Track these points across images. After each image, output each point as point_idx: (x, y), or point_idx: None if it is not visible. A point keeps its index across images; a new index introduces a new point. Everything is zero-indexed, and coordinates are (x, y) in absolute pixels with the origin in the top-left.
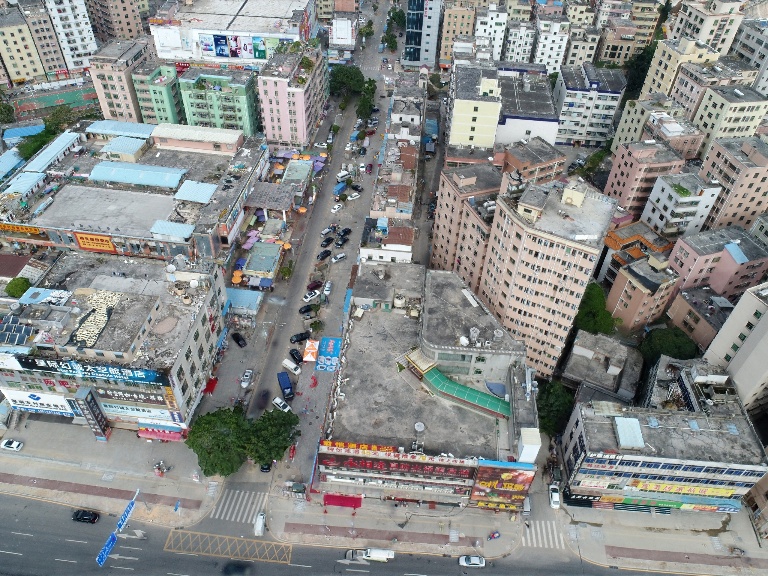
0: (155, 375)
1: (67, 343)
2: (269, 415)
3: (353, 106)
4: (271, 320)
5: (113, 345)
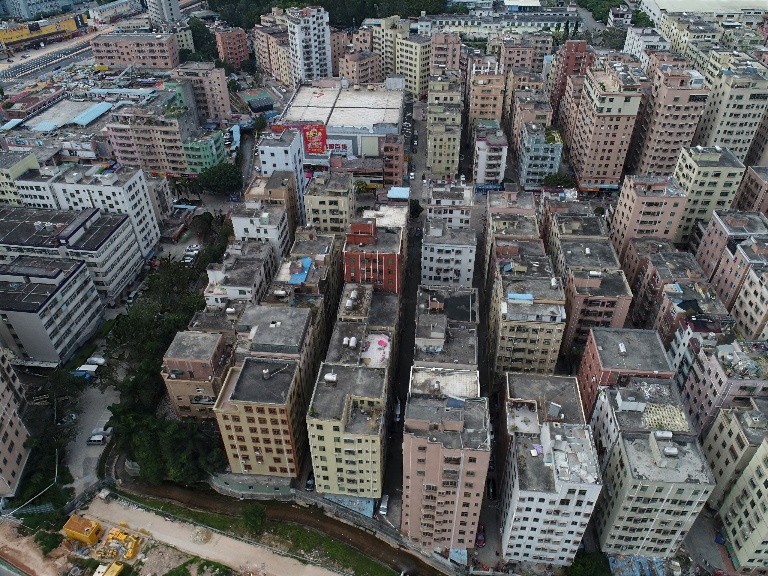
0: None
1: None
2: None
3: (208, 198)
4: None
5: None
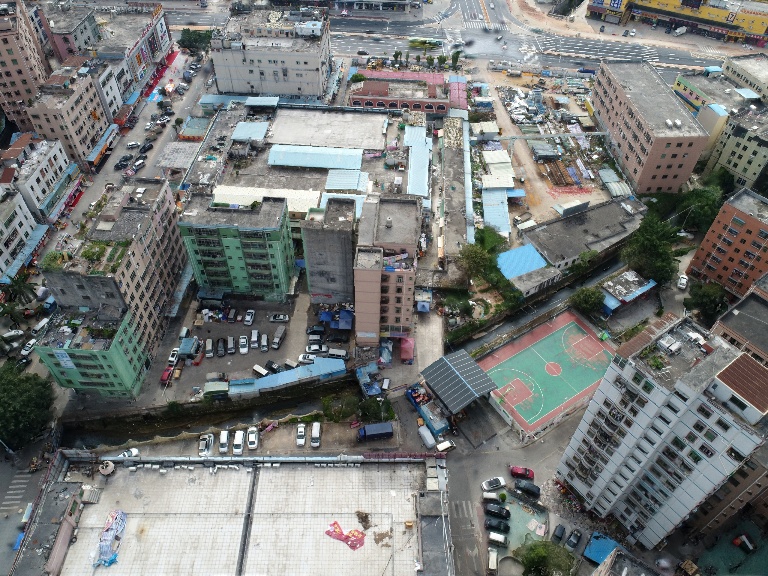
0: (238, 9)
1: (284, 11)
2: (191, 38)
3: None
4: (196, 109)
5: (261, 11)
